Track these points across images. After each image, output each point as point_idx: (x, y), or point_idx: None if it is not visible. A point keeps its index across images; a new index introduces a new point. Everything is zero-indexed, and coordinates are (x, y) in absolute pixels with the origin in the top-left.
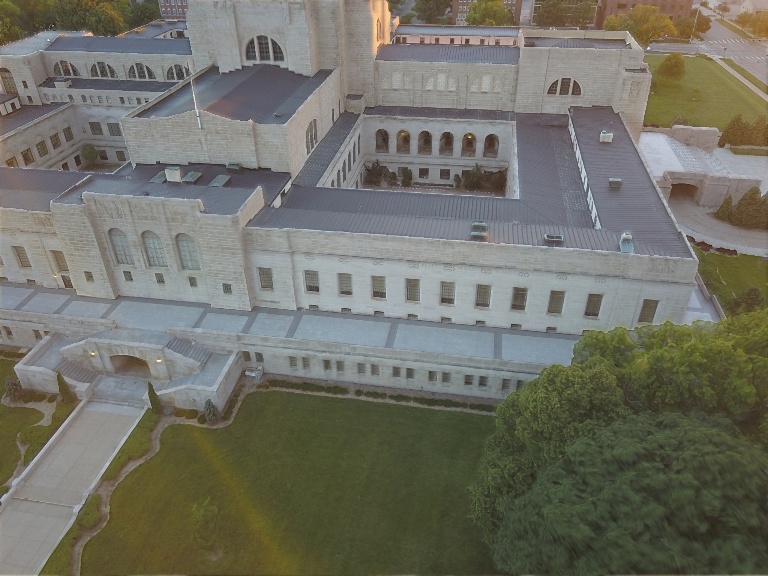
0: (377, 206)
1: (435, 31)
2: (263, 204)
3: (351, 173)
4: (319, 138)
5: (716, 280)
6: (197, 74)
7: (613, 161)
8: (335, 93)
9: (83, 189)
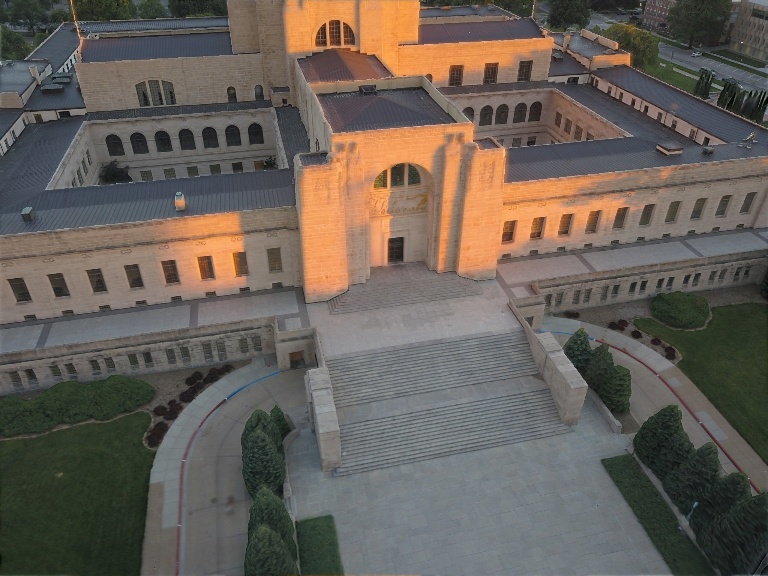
0: (50, 146)
1: (633, 84)
2: (19, 106)
3: (219, 150)
4: (182, 102)
5: (43, 405)
6: (223, 30)
7: (112, 214)
8: (243, 75)
9: (27, 63)
